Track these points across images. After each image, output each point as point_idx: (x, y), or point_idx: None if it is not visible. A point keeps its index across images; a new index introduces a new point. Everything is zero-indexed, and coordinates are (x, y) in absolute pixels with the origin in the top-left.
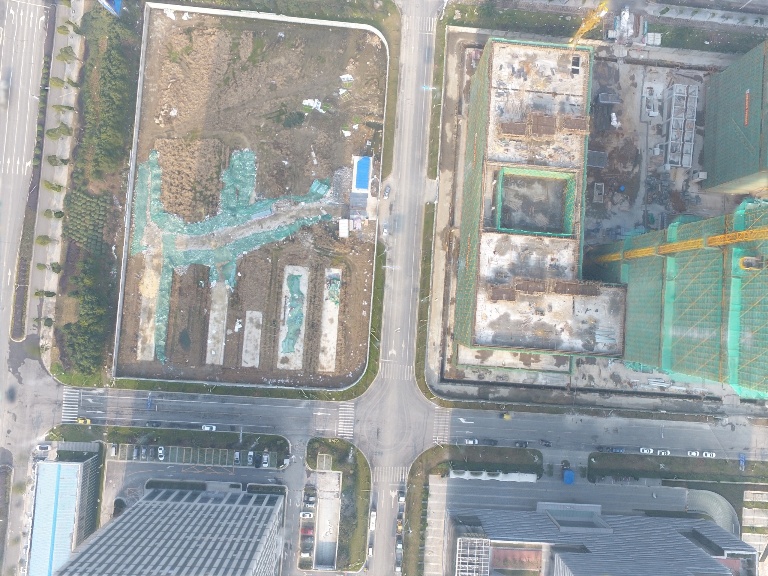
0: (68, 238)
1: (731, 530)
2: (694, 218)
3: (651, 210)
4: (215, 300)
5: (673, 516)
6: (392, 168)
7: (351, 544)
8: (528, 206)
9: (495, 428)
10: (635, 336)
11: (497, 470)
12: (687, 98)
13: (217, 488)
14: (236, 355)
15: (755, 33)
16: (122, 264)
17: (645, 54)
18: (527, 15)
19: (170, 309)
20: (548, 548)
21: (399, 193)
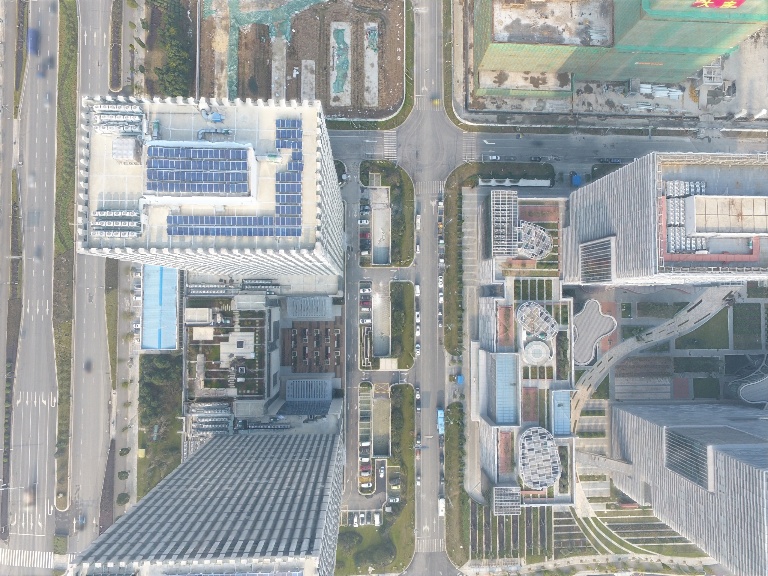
0: (151, 4)
1: None
2: None
3: None
4: (275, 52)
5: None
6: None
7: (401, 244)
8: None
9: (513, 147)
10: (622, 17)
11: (517, 179)
12: None
13: None
14: (296, 96)
15: None
16: (197, 23)
17: None
18: None
19: (239, 61)
20: (563, 204)
21: None
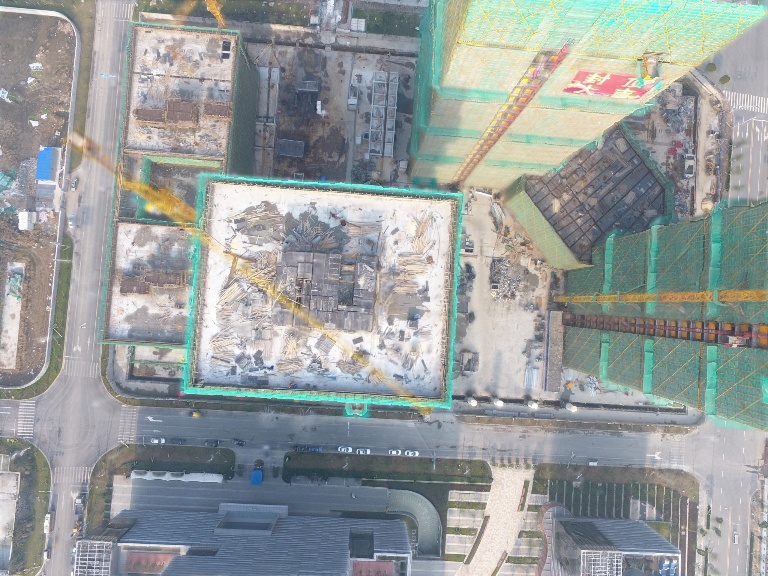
0: None
1: (437, 531)
2: None
3: None
4: None
5: (367, 517)
6: (82, 159)
7: (27, 548)
8: (192, 196)
9: (185, 427)
10: None
11: (184, 470)
12: (388, 85)
13: None
14: None
15: None
16: None
17: (354, 41)
18: (228, 1)
19: None
20: (186, 551)
21: (89, 184)
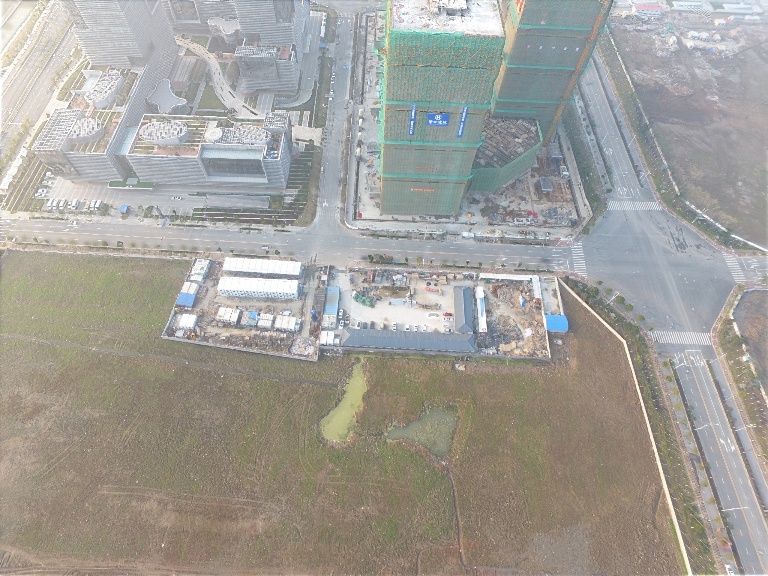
0: None
1: None
2: None
3: None
4: None
5: None
6: None
7: None
8: None
9: (346, 29)
10: None
11: None
12: None
13: None
14: None
15: (577, 120)
16: None
17: None
18: None
19: None
20: None
21: None
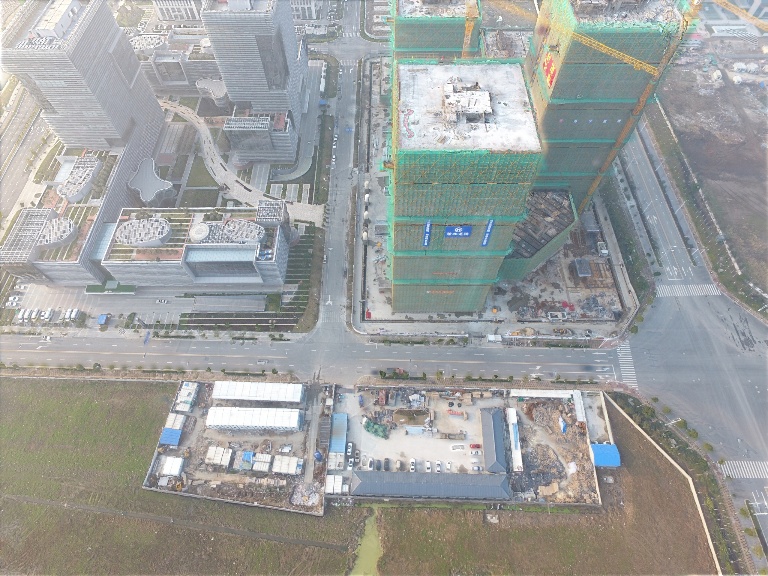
0: None
1: None
2: None
3: None
4: None
5: None
6: None
7: None
8: None
9: (348, 80)
10: None
11: None
12: None
13: (320, 3)
14: (379, 5)
15: (614, 181)
16: None
17: None
18: None
19: None
20: None
21: None
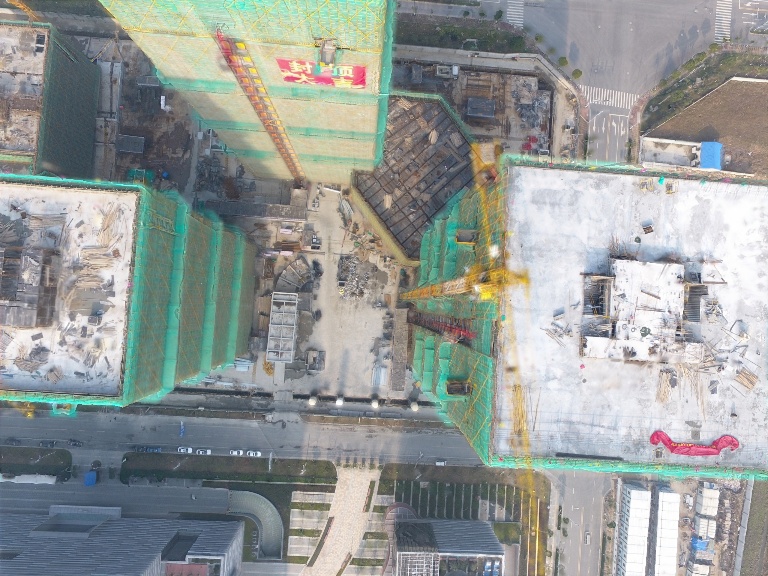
0: None
1: (281, 533)
2: (236, 205)
3: (202, 197)
4: None
5: (204, 519)
6: None
7: None
8: None
9: (20, 427)
10: None
11: None
12: None
13: None
14: None
15: None
16: None
17: None
18: None
19: None
20: None
21: None
